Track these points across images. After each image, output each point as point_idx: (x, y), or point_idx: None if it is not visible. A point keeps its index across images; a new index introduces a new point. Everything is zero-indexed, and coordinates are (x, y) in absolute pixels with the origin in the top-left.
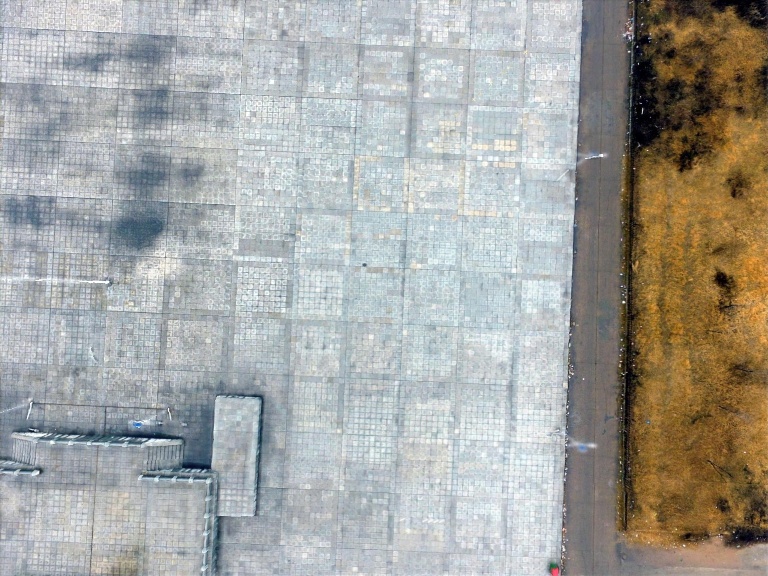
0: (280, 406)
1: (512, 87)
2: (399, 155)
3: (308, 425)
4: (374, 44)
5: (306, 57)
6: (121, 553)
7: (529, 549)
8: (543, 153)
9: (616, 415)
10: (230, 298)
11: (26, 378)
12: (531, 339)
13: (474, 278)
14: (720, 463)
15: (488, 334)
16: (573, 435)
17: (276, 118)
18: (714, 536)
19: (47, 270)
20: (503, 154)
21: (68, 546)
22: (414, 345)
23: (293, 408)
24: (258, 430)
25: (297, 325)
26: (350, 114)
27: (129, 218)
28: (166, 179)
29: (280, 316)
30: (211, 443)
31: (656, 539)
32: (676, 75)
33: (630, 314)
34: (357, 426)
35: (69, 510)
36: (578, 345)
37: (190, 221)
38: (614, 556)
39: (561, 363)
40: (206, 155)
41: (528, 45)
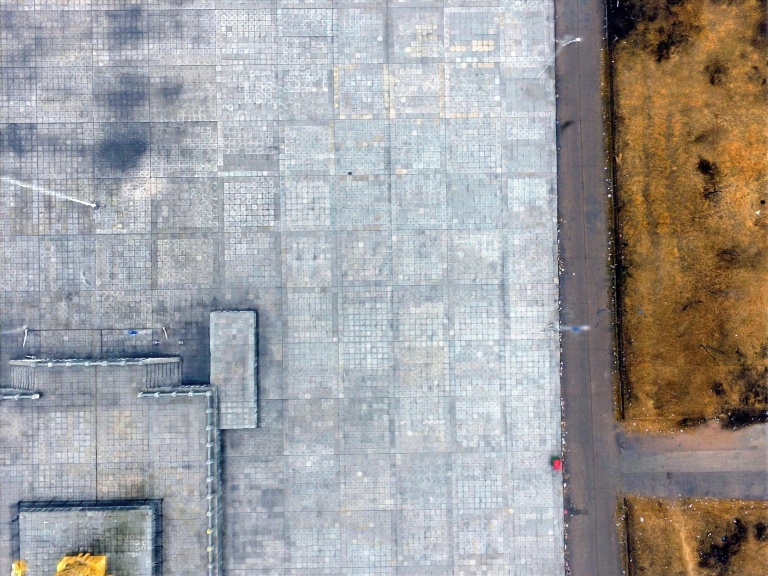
0: (275, 318)
1: None
2: (378, 61)
3: (304, 336)
4: None
5: None
6: (126, 471)
7: (529, 443)
8: (521, 51)
9: (608, 307)
10: (218, 214)
11: (19, 306)
12: (520, 237)
13: (460, 180)
14: (712, 347)
15: (477, 235)
16: (567, 330)
17: (252, 31)
18: (710, 419)
19: (33, 197)
20: (481, 54)
21: (73, 467)
22: (404, 250)
23: (288, 320)
24: (254, 342)
25: (287, 237)
26: (326, 23)
27: (111, 140)
28: (146, 99)
29: (269, 229)
30: (209, 359)
31: (654, 426)
32: None
33: (616, 206)
34: (352, 334)
35: (71, 432)
36: (567, 241)
37: (173, 140)
38: (613, 445)
39: (551, 259)
40: (184, 73)
41: None
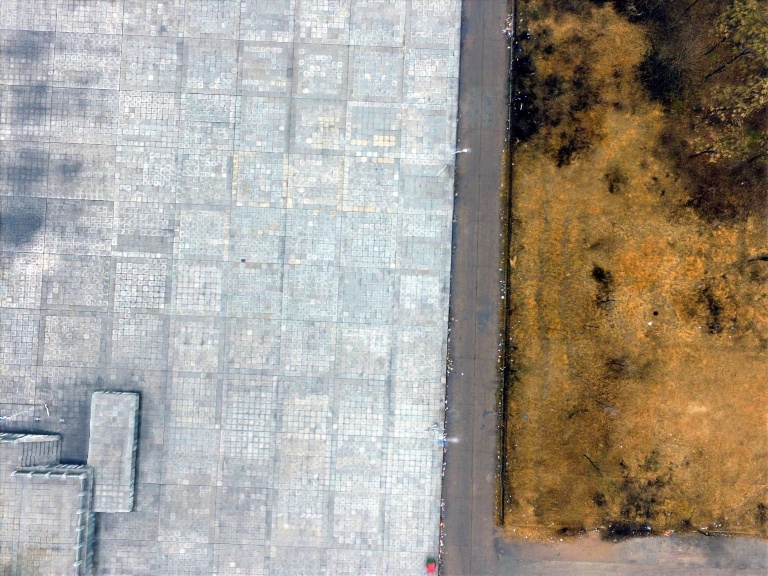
0: (158, 402)
1: (391, 83)
2: (278, 151)
3: (186, 421)
4: (253, 40)
5: (185, 53)
6: None
7: (406, 544)
8: (422, 149)
9: (495, 410)
10: (108, 294)
11: None
12: (409, 334)
13: (353, 273)
14: (596, 457)
15: (366, 329)
16: (452, 430)
17: (155, 114)
18: (591, 530)
19: None
20: (382, 150)
21: None
22: (293, 340)
23: (171, 404)
24: (134, 426)
25: (176, 321)
26: (229, 110)
27: (7, 214)
28: (44, 175)
29: (159, 312)
30: (89, 439)
31: (533, 533)
32: (555, 71)
33: (508, 309)
34: (235, 421)
35: None
36: (457, 340)
37: (68, 217)
38: (492, 551)
39: (439, 358)
40: (85, 151)
41: (407, 41)
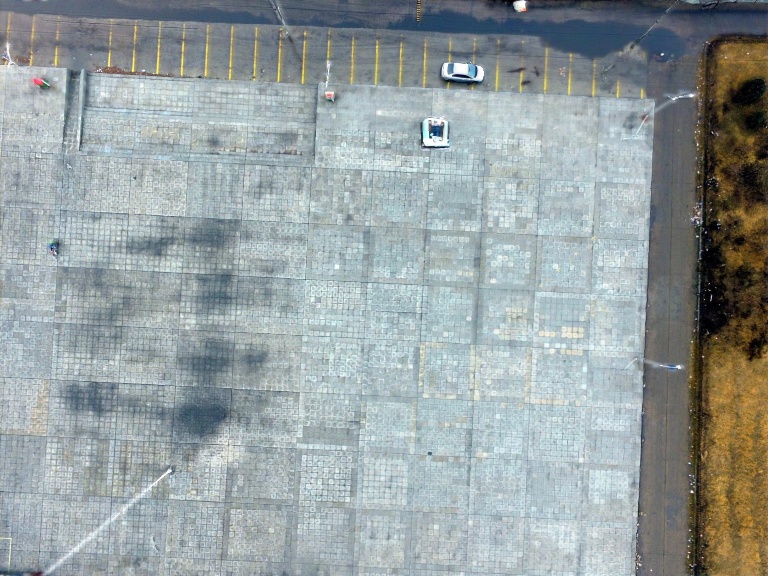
0: None
1: (580, 273)
2: (465, 342)
3: None
4: (440, 229)
5: (372, 242)
6: None
7: None
8: (611, 340)
9: None
10: (294, 487)
11: (87, 568)
12: (599, 530)
13: (541, 467)
14: None
15: (555, 525)
16: None
17: (341, 304)
18: None
19: (109, 458)
20: (570, 341)
21: None
22: (480, 536)
23: None
24: None
25: (361, 515)
26: (416, 300)
27: (192, 405)
28: (230, 365)
29: (344, 505)
30: None
31: None
32: (745, 262)
33: (699, 506)
34: None
35: None
36: (646, 535)
37: (254, 408)
38: None
39: (629, 555)
40: (270, 341)
41: (596, 231)
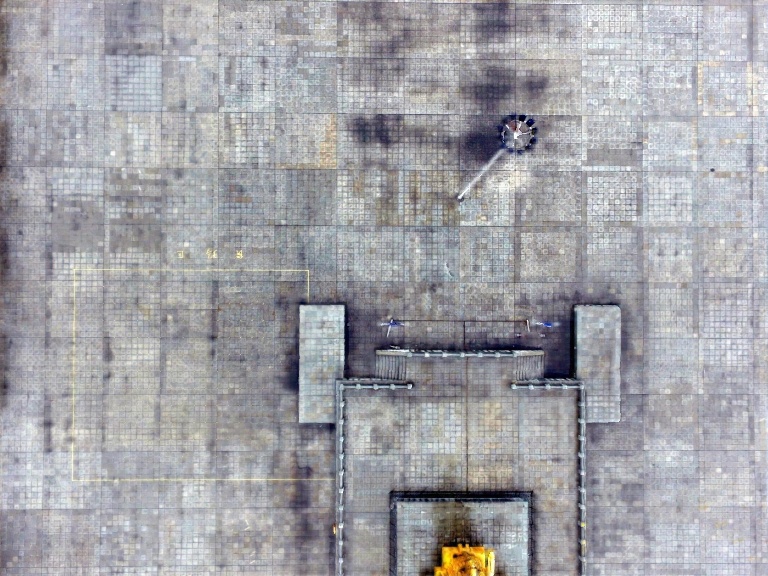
0: (636, 313)
1: None
2: (741, 59)
3: (665, 331)
4: None
5: None
6: (496, 462)
7: None
8: None
9: None
10: (581, 208)
11: (384, 296)
12: None
13: None
14: None
15: None
16: None
17: (618, 27)
18: None
19: (398, 188)
20: None
21: (444, 458)
22: (765, 247)
23: (649, 314)
24: (620, 336)
25: (649, 232)
26: (691, 20)
27: (477, 133)
28: (512, 92)
29: (631, 224)
30: (570, 353)
31: None
32: None
33: None
34: (713, 329)
35: (442, 422)
36: None
37: (538, 133)
38: None
39: None
40: (550, 66)
41: None
